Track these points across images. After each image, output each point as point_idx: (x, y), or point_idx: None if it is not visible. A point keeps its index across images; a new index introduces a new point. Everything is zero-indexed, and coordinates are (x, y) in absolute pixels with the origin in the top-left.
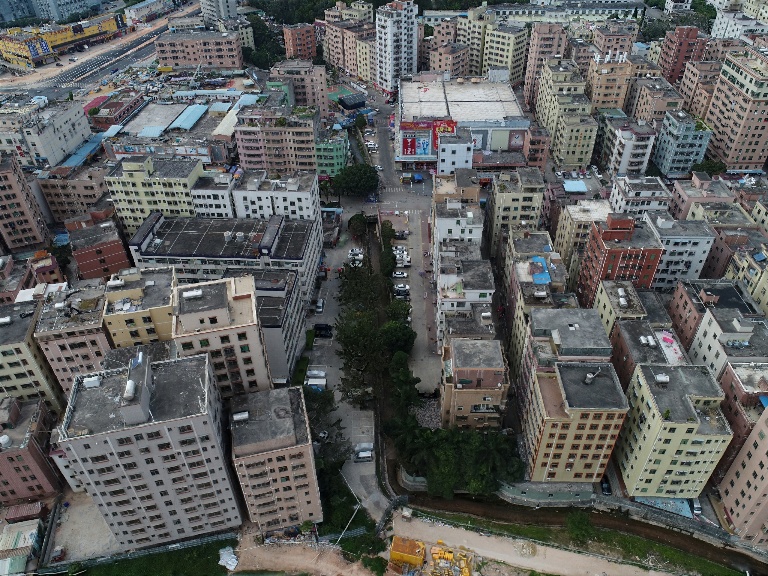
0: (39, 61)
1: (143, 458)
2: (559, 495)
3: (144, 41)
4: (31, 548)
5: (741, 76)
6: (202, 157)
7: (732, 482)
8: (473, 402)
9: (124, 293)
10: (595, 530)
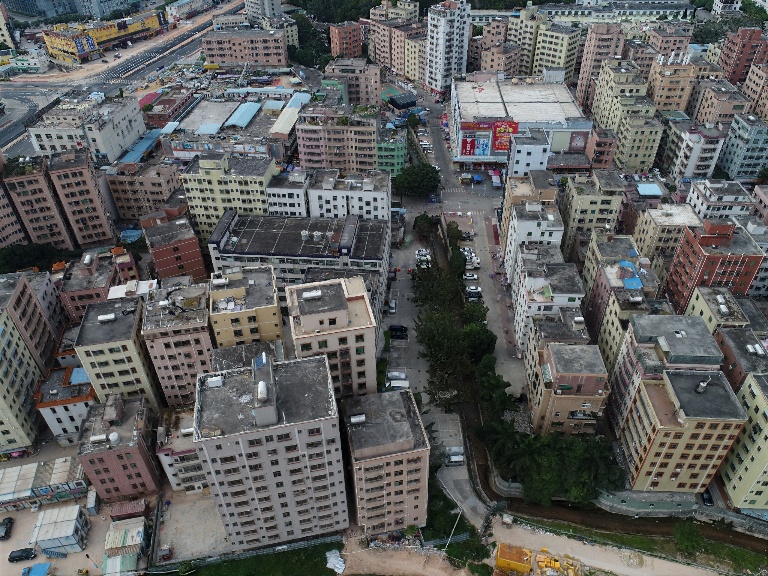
0: (85, 57)
1: (269, 460)
2: (660, 505)
3: (186, 38)
4: (140, 546)
5: None
6: None
7: None
8: (572, 408)
9: (228, 292)
10: None
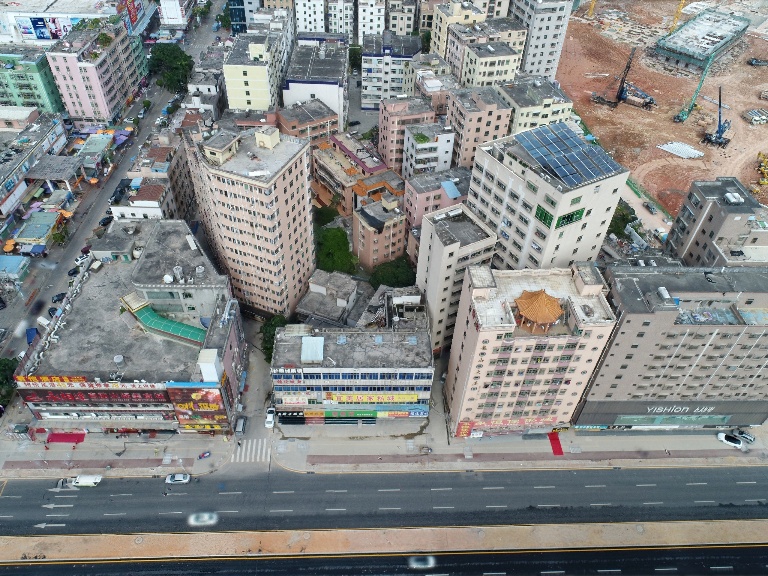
0: None
1: None
2: None
3: None
4: None
5: None
6: (60, 139)
7: None
8: None
9: None
10: None
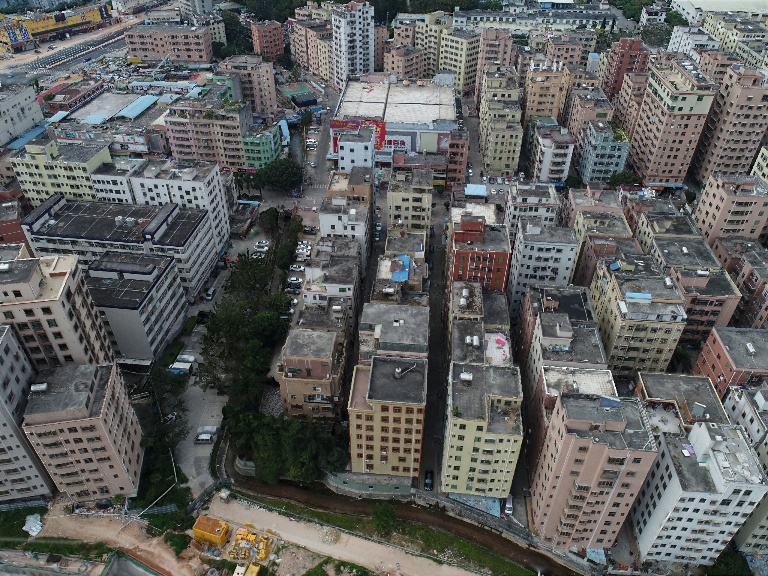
0: (18, 47)
1: None
2: (379, 487)
3: None
4: None
5: (661, 89)
6: (139, 146)
7: (537, 484)
8: (304, 391)
9: None
10: (405, 523)
